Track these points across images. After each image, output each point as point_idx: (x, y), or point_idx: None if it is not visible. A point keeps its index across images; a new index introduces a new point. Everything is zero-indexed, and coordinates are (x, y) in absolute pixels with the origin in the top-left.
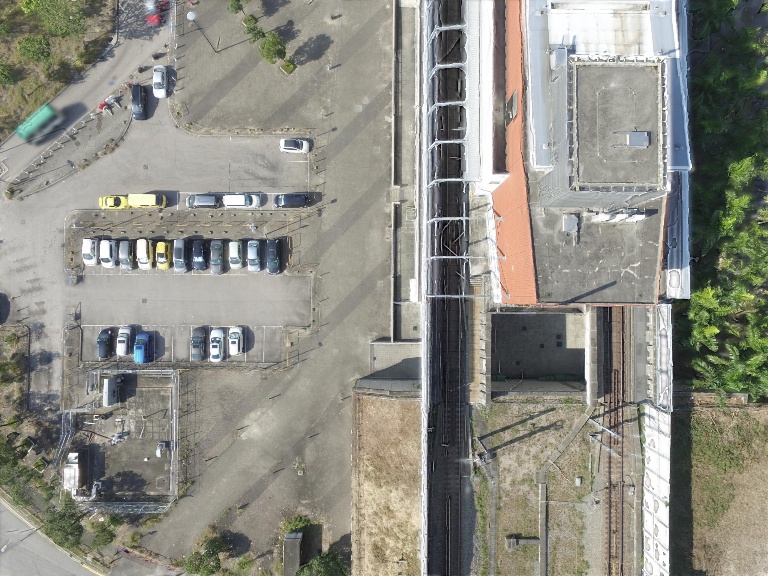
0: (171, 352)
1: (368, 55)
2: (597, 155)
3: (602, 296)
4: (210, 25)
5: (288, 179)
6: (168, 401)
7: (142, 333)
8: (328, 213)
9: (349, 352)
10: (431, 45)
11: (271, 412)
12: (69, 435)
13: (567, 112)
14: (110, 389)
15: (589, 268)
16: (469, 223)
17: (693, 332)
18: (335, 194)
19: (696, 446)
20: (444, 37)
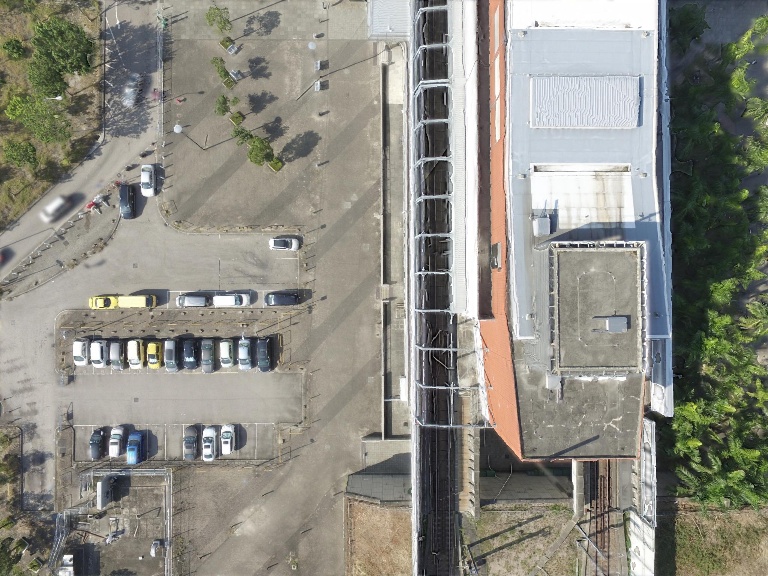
0: (164, 451)
1: (356, 151)
2: (578, 340)
3: (585, 450)
4: (197, 122)
5: (278, 276)
6: (162, 499)
7: (134, 433)
8: (318, 310)
9: (341, 448)
10: (418, 168)
11: (264, 508)
12: (63, 536)
13: (549, 297)
14: (103, 491)
15: (572, 423)
16: (457, 336)
17: (677, 445)
18: (325, 291)
19: (680, 549)
20: (431, 150)
